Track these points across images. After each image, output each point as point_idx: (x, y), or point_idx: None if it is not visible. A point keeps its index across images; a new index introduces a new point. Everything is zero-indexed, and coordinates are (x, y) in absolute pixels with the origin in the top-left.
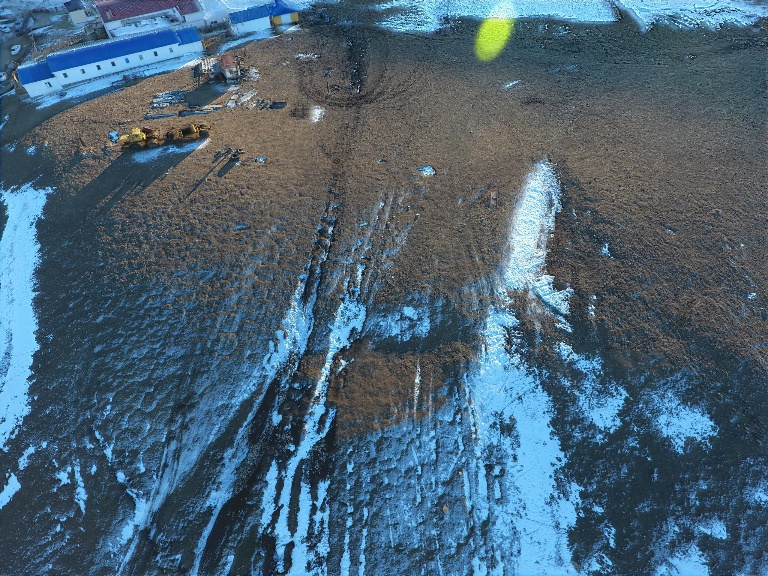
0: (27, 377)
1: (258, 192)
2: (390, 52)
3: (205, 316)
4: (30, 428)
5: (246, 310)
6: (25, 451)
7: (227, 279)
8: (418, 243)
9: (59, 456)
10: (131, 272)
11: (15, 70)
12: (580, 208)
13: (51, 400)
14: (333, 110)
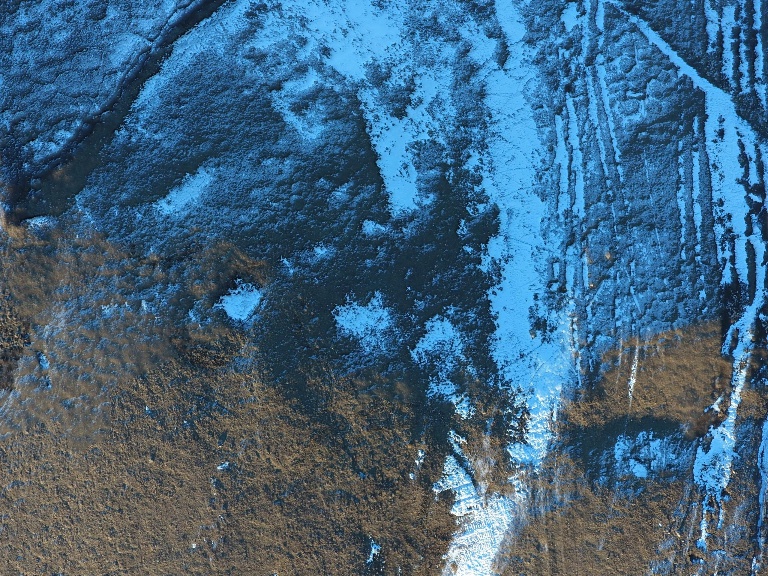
0: None
1: None
2: None
3: None
4: None
5: None
6: None
7: None
8: None
9: None
10: None
11: None
12: None
13: None
14: None
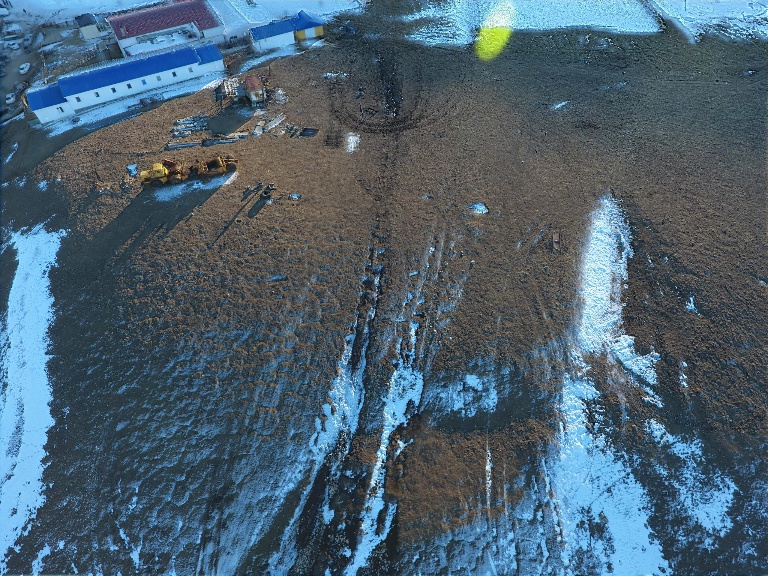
0: (41, 459)
1: (294, 236)
2: (424, 69)
3: (241, 387)
4: (45, 523)
5: (287, 379)
6: (39, 552)
7: (264, 341)
8: (476, 296)
9: (79, 559)
10: (156, 332)
11: (24, 91)
12: (655, 253)
13: (68, 489)
14: (369, 137)
